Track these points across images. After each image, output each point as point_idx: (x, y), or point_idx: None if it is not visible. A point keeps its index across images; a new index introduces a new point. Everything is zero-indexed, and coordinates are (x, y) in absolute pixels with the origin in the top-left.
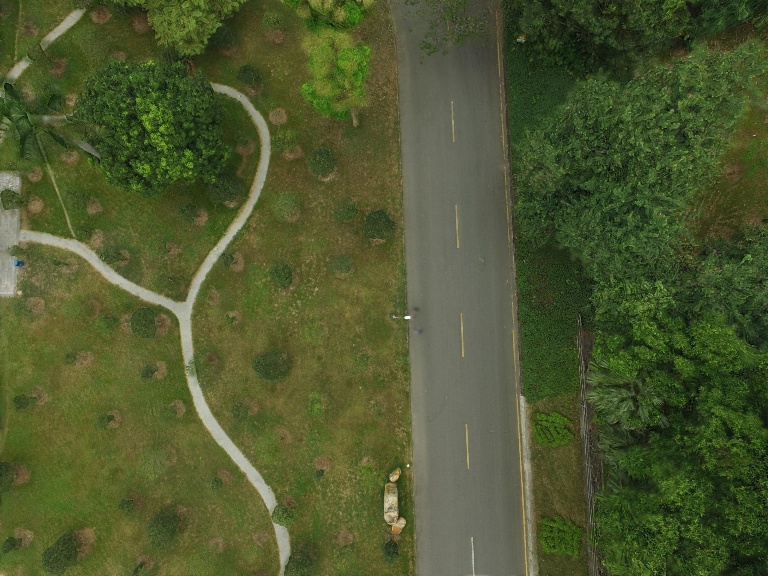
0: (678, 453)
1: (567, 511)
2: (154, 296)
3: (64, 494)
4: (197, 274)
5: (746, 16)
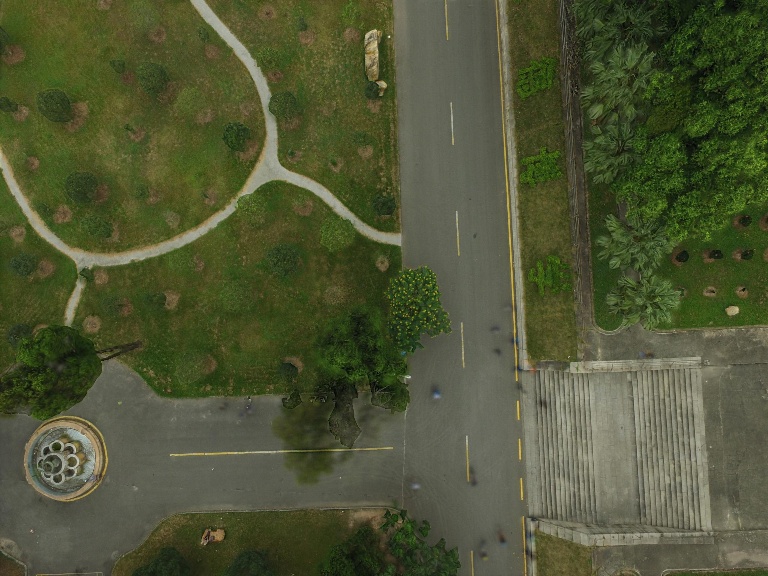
0: None
1: (541, 51)
2: None
3: (58, 71)
4: None
5: None
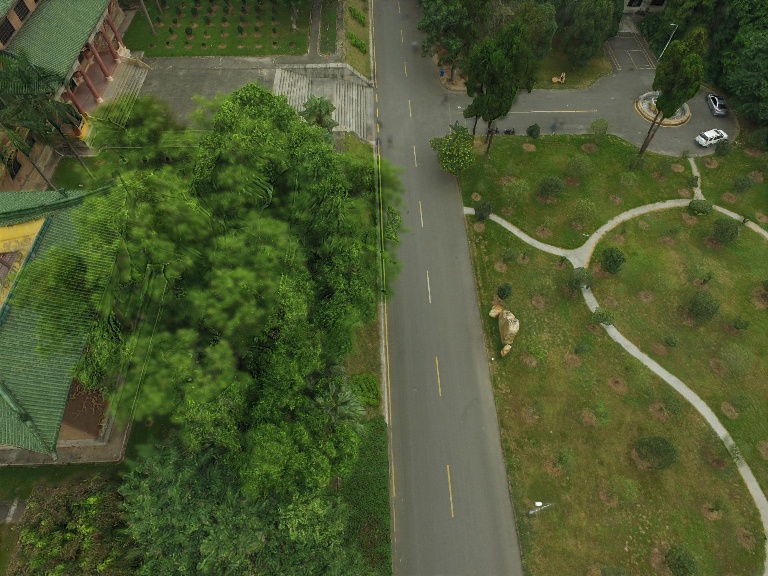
0: None
1: None
2: None
3: None
4: None
5: None
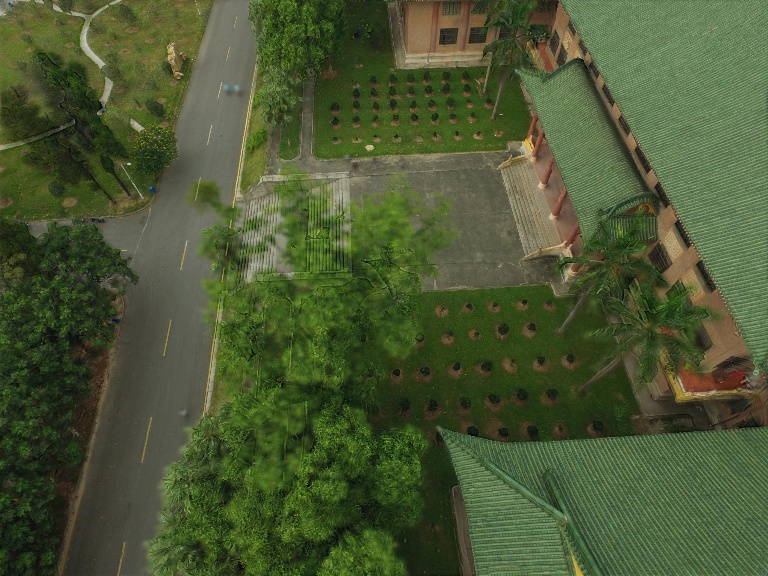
0: None
1: None
2: (76, 13)
3: None
4: (102, 7)
5: None
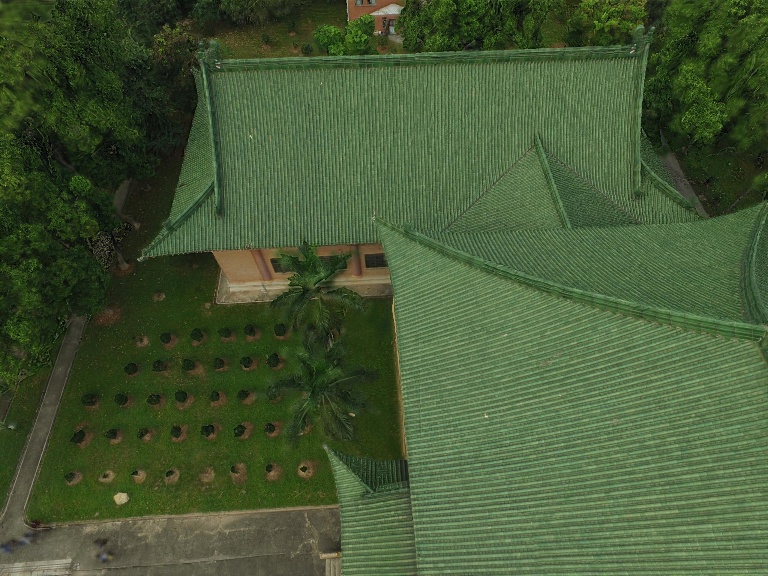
0: (7, 99)
1: None
2: None
3: None
4: None
5: (210, 1)
